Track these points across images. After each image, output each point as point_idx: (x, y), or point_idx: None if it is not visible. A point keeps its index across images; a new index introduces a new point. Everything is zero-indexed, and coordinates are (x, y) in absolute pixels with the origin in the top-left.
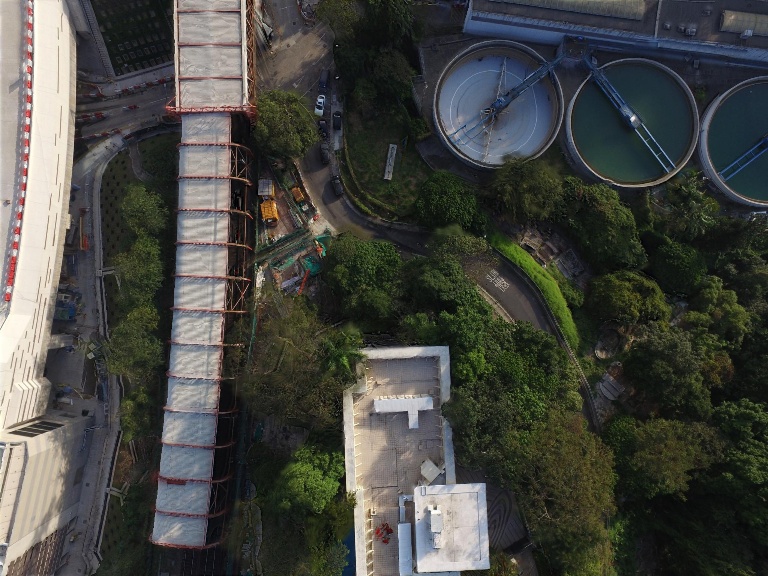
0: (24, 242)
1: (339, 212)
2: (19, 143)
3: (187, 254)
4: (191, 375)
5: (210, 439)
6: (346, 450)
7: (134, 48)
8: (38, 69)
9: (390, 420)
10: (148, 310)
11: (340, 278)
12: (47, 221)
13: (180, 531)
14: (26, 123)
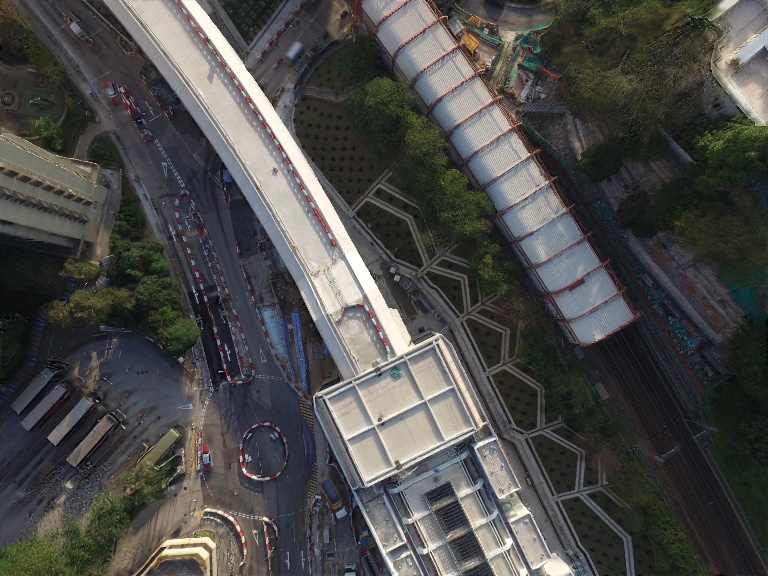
0: (312, 193)
1: (513, 17)
2: (249, 118)
3: (450, 104)
4: (526, 195)
5: (576, 234)
6: (741, 108)
7: (252, 7)
8: (219, 48)
9: (751, 68)
10: (453, 170)
11: (598, 21)
12: (311, 170)
13: (608, 319)
14: (244, 95)
